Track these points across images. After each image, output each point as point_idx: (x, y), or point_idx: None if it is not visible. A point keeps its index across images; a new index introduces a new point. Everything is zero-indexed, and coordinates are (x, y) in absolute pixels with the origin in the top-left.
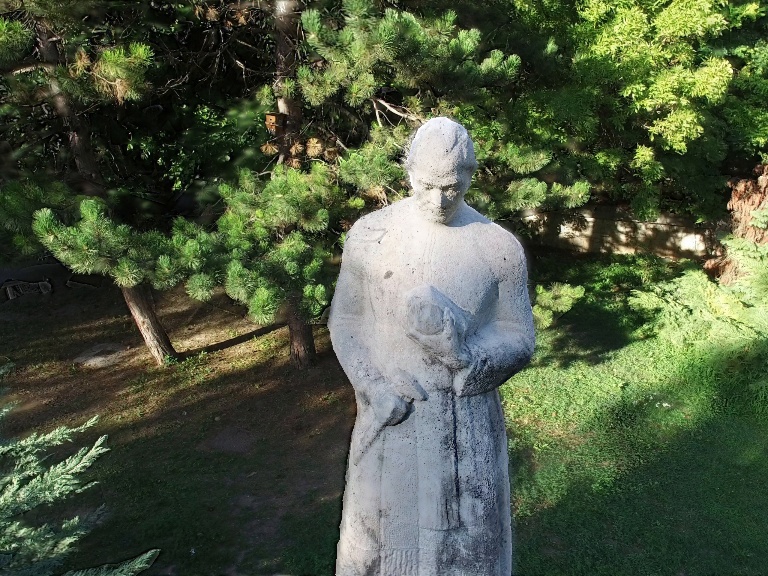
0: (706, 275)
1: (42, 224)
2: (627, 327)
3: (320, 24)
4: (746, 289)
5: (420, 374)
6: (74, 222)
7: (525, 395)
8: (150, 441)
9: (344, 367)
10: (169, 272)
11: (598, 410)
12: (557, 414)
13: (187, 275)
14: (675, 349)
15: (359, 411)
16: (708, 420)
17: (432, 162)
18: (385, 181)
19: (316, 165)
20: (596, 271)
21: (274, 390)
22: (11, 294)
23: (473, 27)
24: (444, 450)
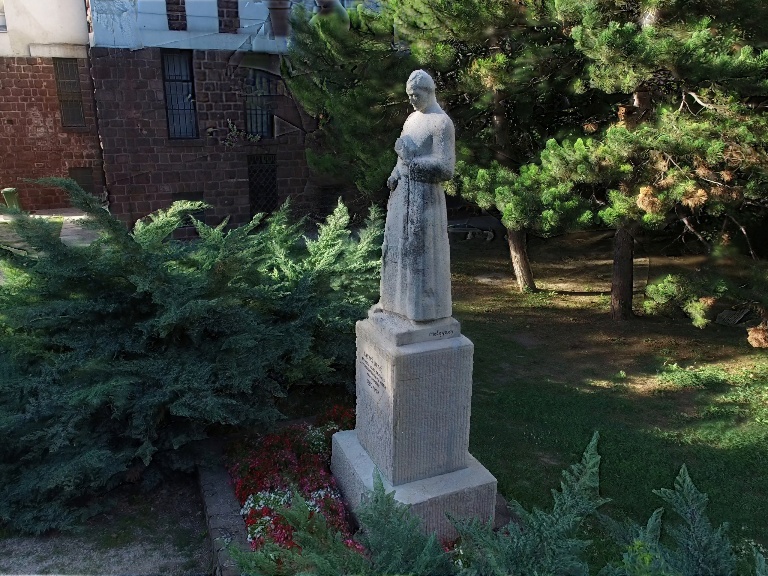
0: None
1: None
2: None
3: (581, 35)
4: None
5: None
6: None
7: None
8: (479, 323)
9: None
10: (469, 188)
11: None
12: None
13: None
14: None
15: None
16: None
17: None
18: (627, 148)
19: None
20: None
21: (581, 324)
22: (469, 236)
23: (766, 27)
24: None
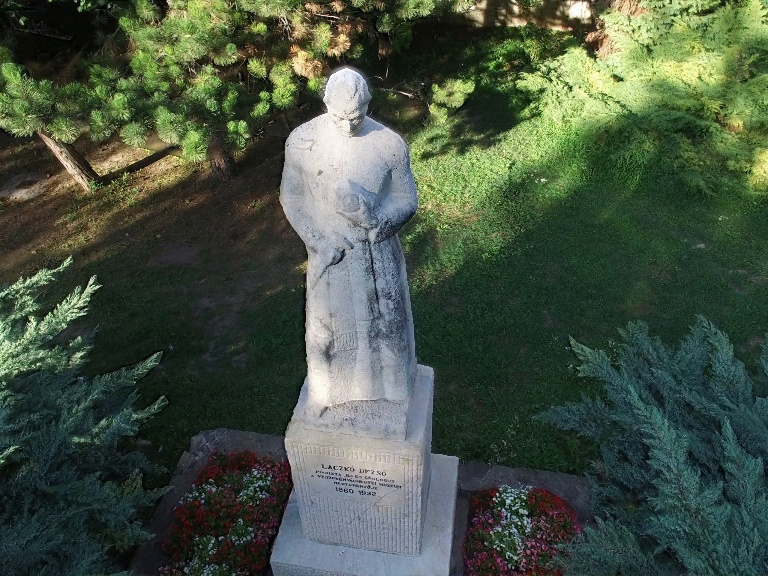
0: (586, 51)
1: None
2: (516, 107)
3: None
4: (618, 63)
5: (348, 234)
6: (1, 88)
7: (428, 183)
8: (103, 264)
9: (297, 231)
10: (103, 125)
11: (489, 190)
12: (455, 198)
13: (120, 125)
14: (556, 126)
15: (310, 257)
16: (576, 189)
17: (342, 106)
18: (285, 11)
19: None
20: (490, 48)
21: (204, 203)
22: None
23: None
24: (367, 276)
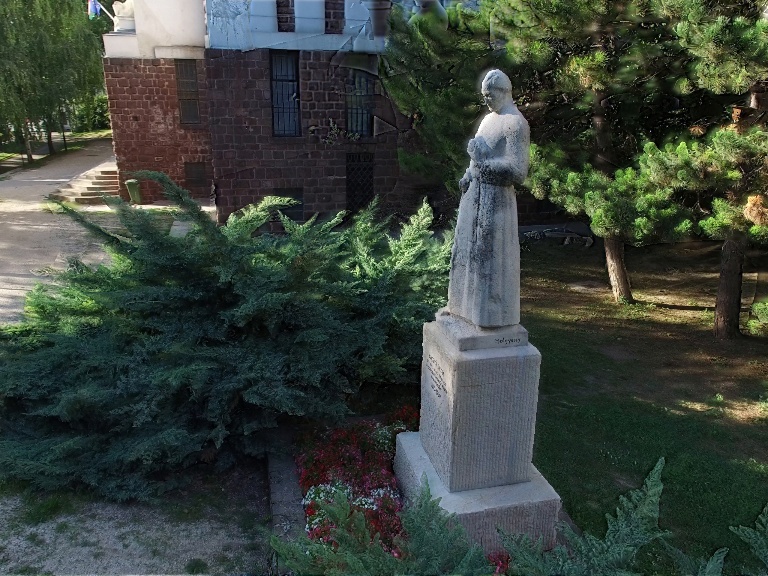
0: None
1: None
2: None
3: (687, 31)
4: None
5: None
6: None
7: None
8: (567, 332)
9: None
10: (558, 191)
11: None
12: None
13: None
14: None
15: None
16: None
17: None
18: (735, 153)
19: None
20: None
21: (679, 341)
22: (567, 241)
23: None
24: None
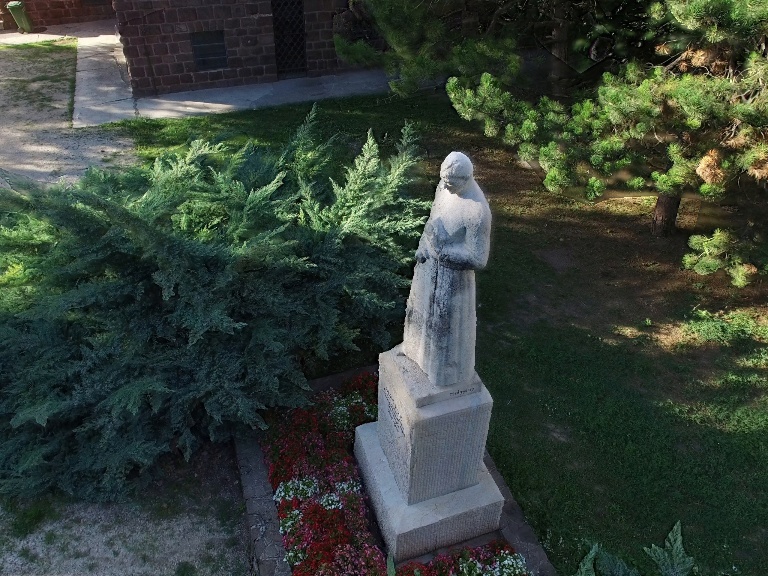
0: None
1: (450, 86)
2: None
3: None
4: None
5: None
6: (474, 86)
7: None
8: (512, 232)
9: None
10: (512, 135)
11: None
12: None
13: (522, 141)
14: None
15: None
16: None
17: None
18: (698, 118)
19: (686, 77)
20: None
21: (618, 240)
22: None
23: None
24: (432, 282)
